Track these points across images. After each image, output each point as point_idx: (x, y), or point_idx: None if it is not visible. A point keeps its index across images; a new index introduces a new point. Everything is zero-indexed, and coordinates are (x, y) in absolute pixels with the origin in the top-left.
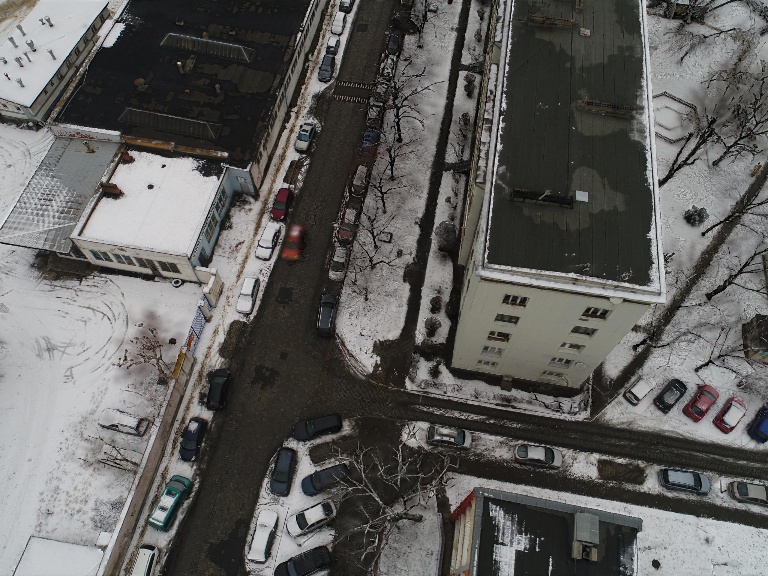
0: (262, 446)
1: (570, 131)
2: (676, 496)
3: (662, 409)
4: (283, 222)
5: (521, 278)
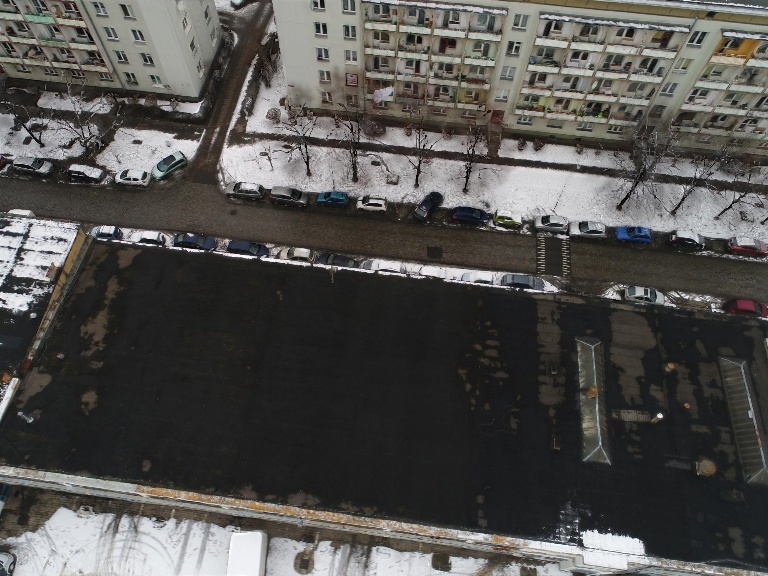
0: None
1: None
2: None
3: None
4: None
5: None
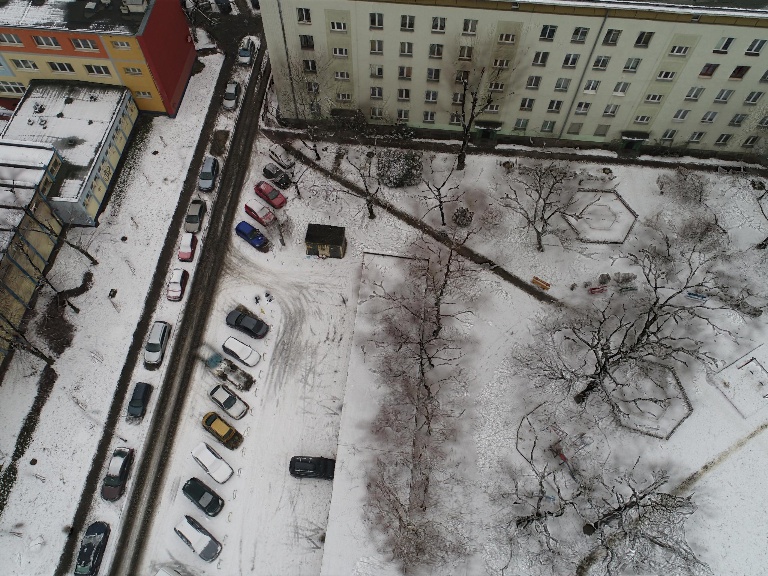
0: None
1: None
2: None
3: None
4: None
5: None
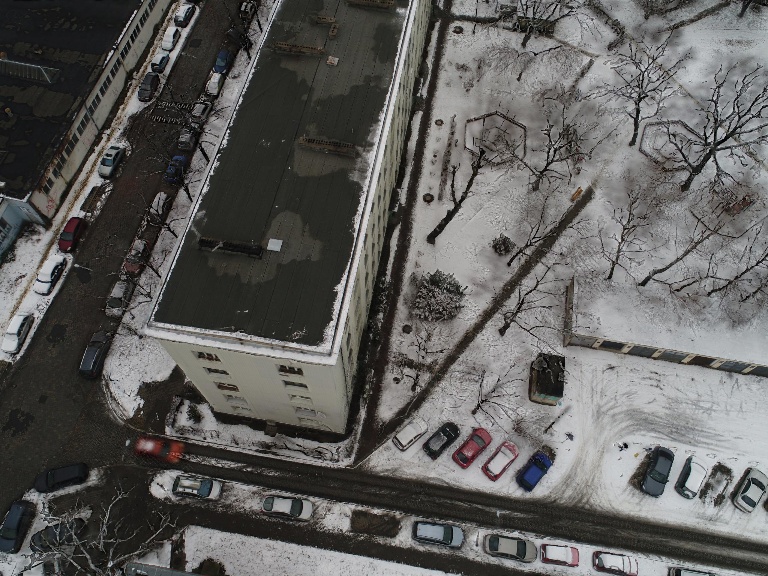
0: (0, 498)
1: (284, 171)
2: (428, 550)
3: (429, 455)
4: (71, 253)
5: (186, 337)
